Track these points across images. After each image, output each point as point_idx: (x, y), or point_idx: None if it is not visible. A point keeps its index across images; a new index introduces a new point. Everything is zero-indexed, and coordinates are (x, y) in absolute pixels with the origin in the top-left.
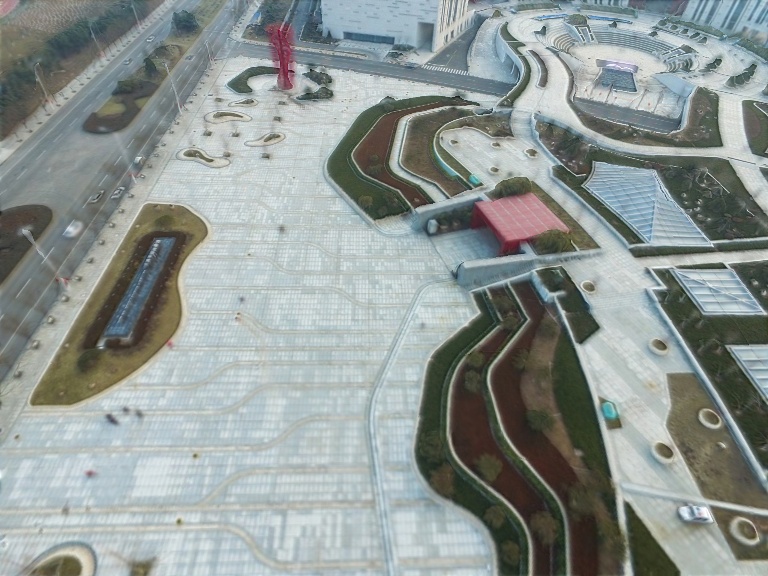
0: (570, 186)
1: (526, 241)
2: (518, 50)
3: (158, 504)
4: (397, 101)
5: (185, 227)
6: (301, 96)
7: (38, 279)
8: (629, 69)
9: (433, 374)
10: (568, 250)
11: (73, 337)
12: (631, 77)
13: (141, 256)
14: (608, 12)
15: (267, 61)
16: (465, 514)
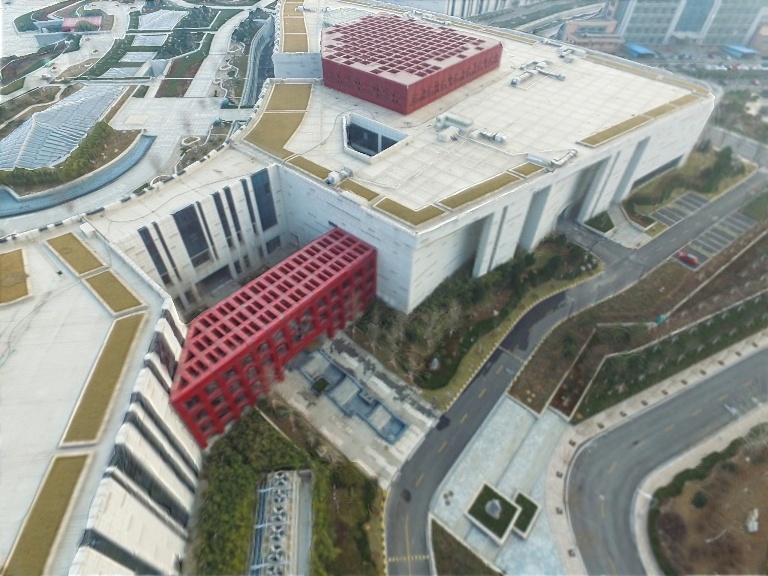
0: (131, 16)
1: (74, 28)
2: None
3: None
4: None
5: None
6: None
7: None
8: None
9: None
10: (92, 30)
11: None
12: None
13: None
14: None
15: None
16: None
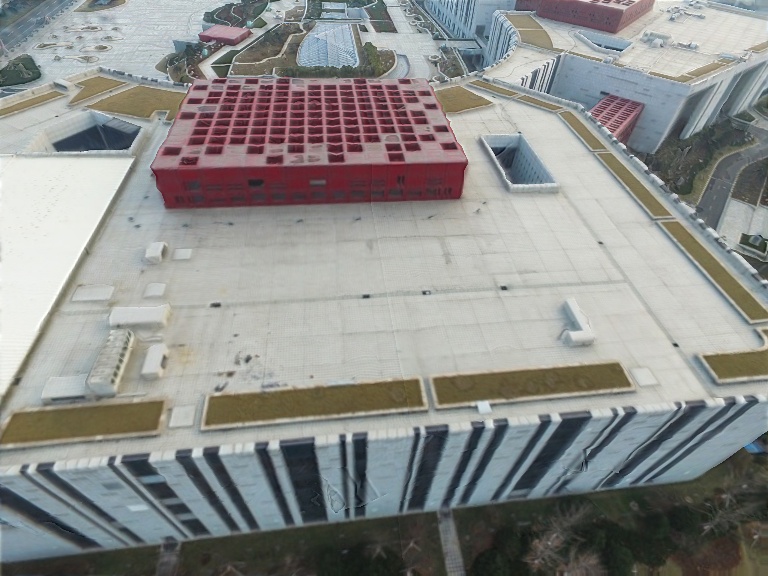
0: None
1: None
2: None
3: None
4: None
5: None
6: None
7: None
8: None
9: (216, 9)
10: None
11: None
12: None
13: None
14: None
15: None
16: None
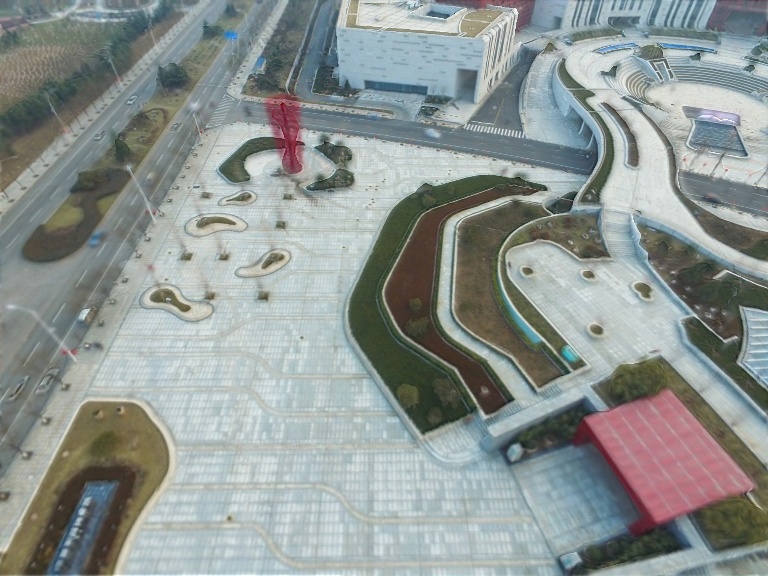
0: (721, 365)
1: (685, 514)
2: (587, 103)
3: None
4: (438, 187)
5: (136, 454)
6: (313, 185)
7: None
8: (730, 121)
9: None
10: (763, 537)
11: None
12: (735, 133)
13: (59, 530)
14: (683, 38)
15: (271, 128)
16: None
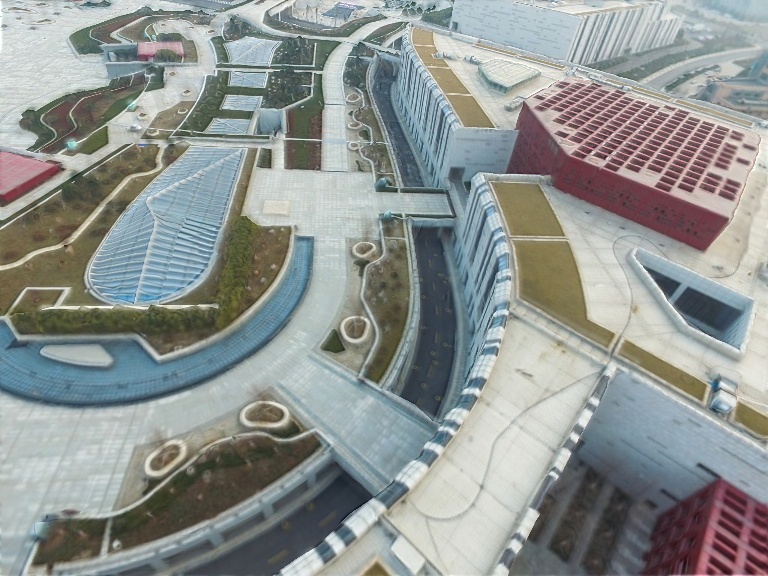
0: (214, 43)
1: (153, 57)
2: None
3: None
4: (155, 11)
5: None
6: (83, 4)
7: None
8: (353, 7)
9: (56, 100)
10: (175, 61)
11: None
12: (351, 12)
13: None
14: None
15: None
16: (32, 135)
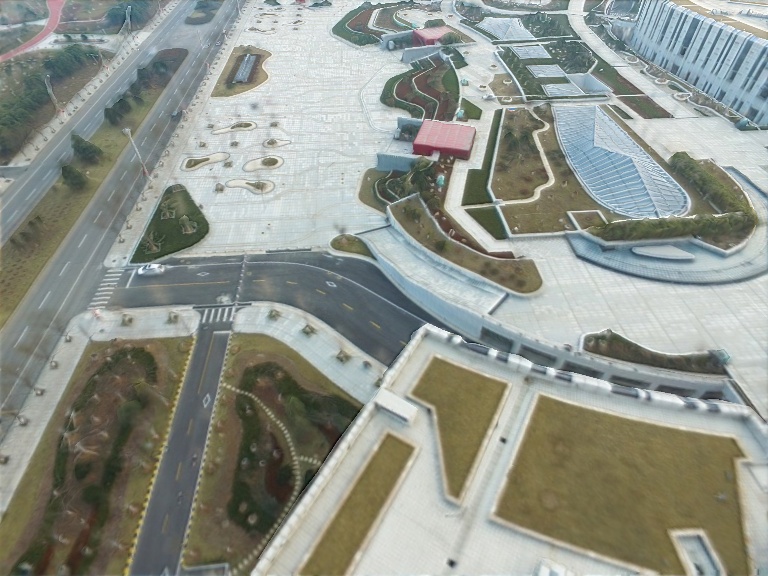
0: (468, 25)
1: (438, 41)
2: None
3: (276, 114)
4: (373, 5)
5: (259, 53)
6: (312, 5)
7: (193, 70)
8: None
9: (389, 83)
10: (459, 42)
11: (220, 82)
12: None
13: (241, 61)
14: None
15: None
16: (400, 110)
